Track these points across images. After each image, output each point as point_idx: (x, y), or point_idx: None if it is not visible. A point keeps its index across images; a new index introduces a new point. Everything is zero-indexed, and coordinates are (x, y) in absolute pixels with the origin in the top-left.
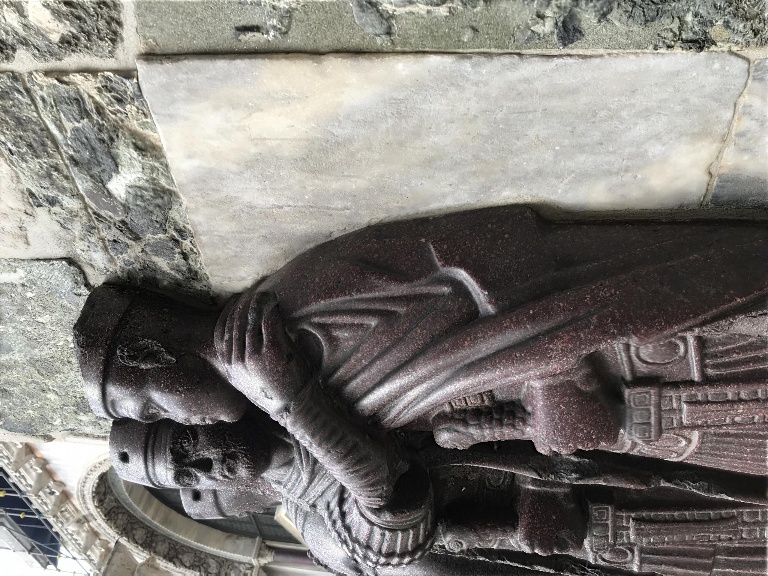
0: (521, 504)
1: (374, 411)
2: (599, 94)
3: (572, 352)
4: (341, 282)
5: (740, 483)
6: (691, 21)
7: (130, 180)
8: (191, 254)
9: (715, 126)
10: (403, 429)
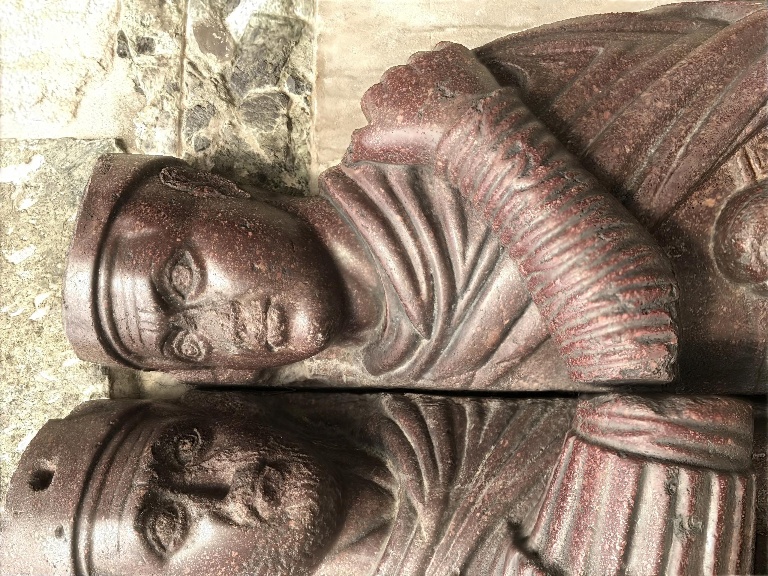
0: None
1: (623, 158)
2: None
3: None
4: None
5: None
6: None
7: (260, 4)
8: (300, 116)
9: None
10: None
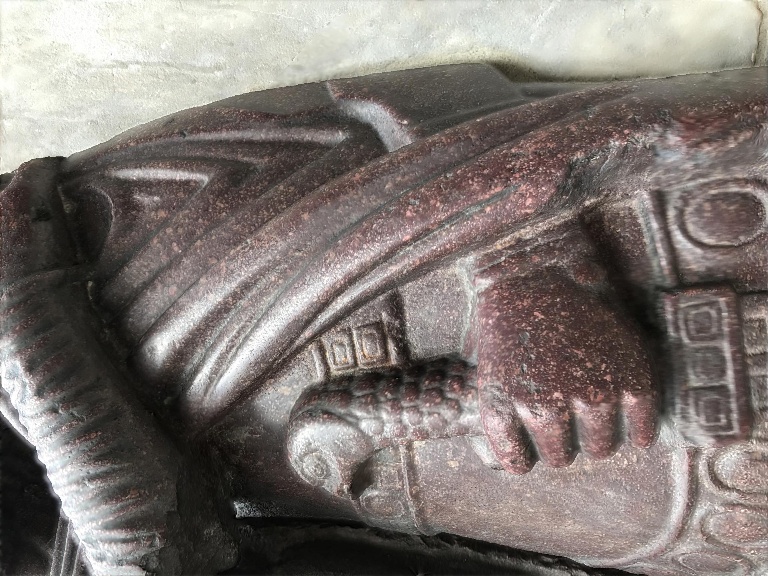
0: None
1: (174, 352)
2: None
3: (554, 156)
4: (172, 121)
5: None
6: None
7: None
8: None
9: None
10: (240, 468)
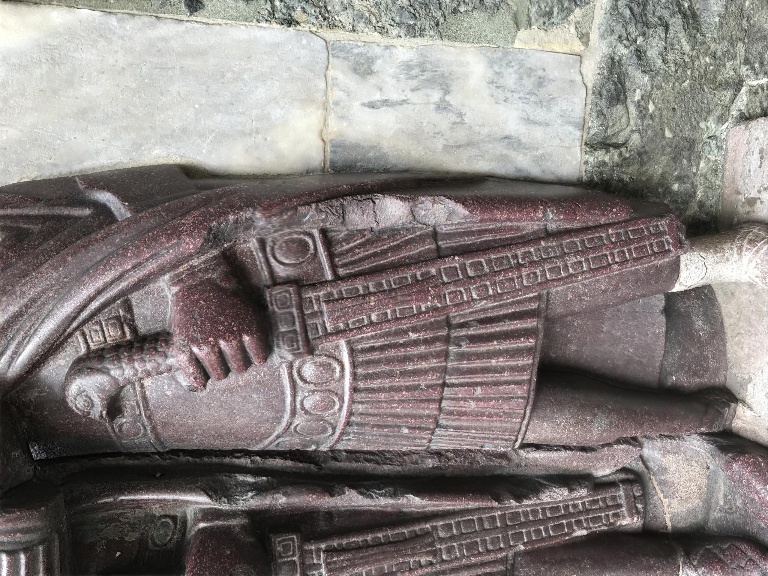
0: (189, 551)
1: None
2: (223, 57)
3: (203, 224)
4: None
5: (425, 485)
6: (279, 5)
7: None
8: None
9: (316, 94)
10: (32, 419)
